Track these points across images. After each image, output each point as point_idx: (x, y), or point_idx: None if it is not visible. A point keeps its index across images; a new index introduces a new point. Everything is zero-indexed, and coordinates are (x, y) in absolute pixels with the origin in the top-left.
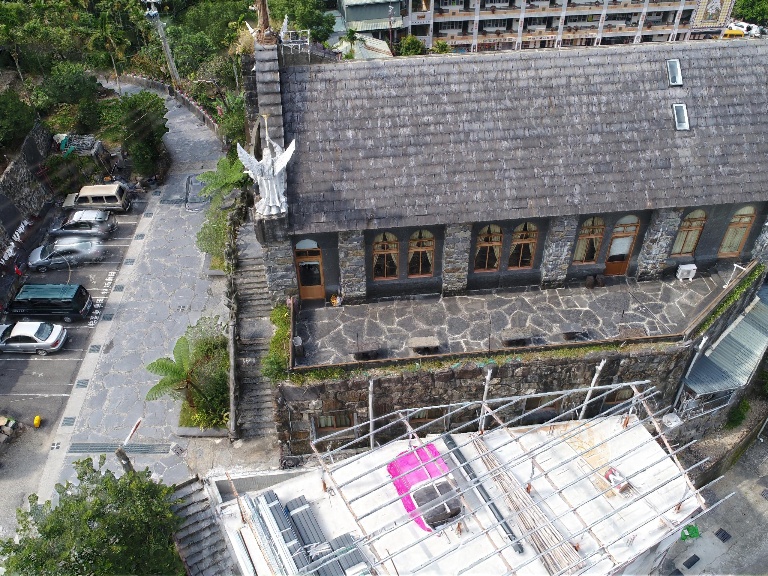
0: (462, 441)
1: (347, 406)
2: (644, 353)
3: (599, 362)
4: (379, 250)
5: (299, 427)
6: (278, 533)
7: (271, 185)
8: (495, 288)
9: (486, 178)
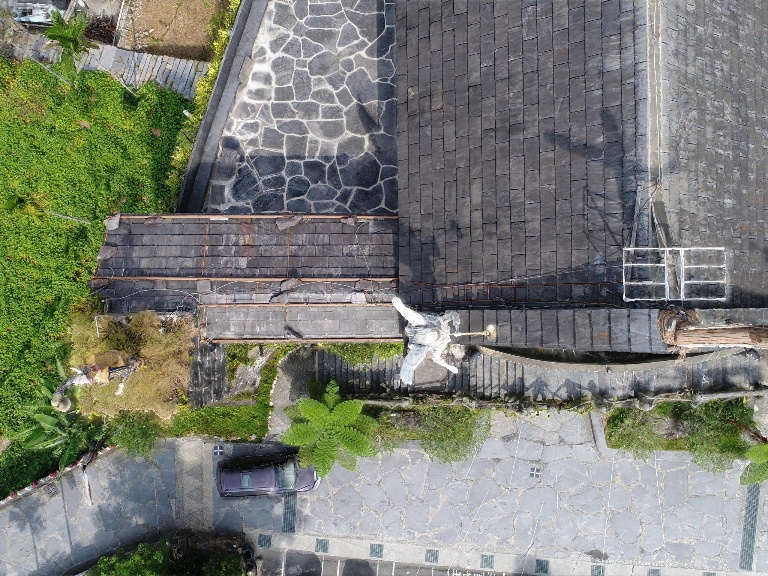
0: None
1: None
2: None
3: None
4: None
5: None
6: None
7: None
8: None
9: (767, 12)
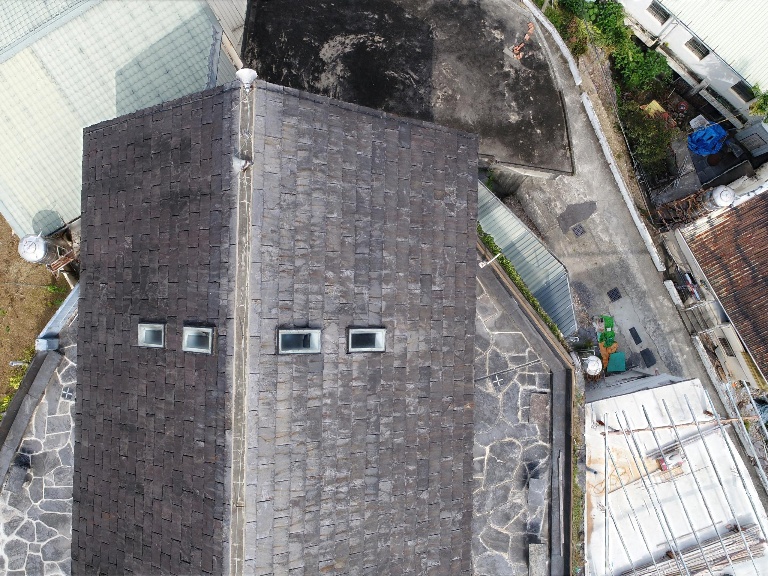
0: None
1: None
2: None
3: None
4: None
5: None
6: None
7: None
8: None
9: None
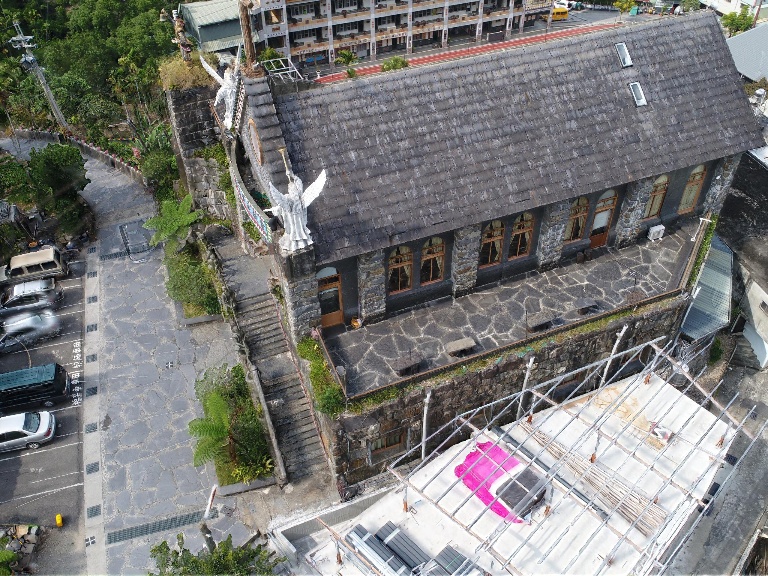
0: (513, 431)
1: (403, 423)
2: (654, 312)
3: (619, 329)
4: (393, 265)
5: (356, 456)
6: (384, 564)
7: (296, 219)
8: (499, 280)
9: (488, 177)
